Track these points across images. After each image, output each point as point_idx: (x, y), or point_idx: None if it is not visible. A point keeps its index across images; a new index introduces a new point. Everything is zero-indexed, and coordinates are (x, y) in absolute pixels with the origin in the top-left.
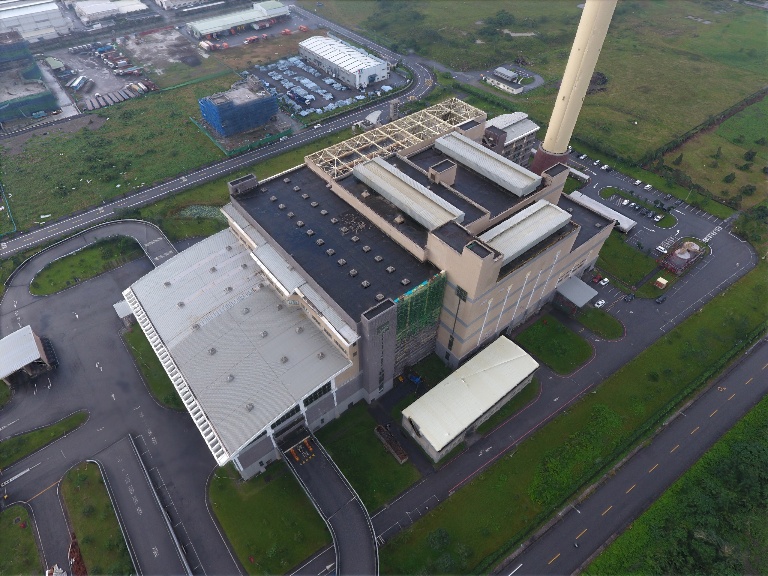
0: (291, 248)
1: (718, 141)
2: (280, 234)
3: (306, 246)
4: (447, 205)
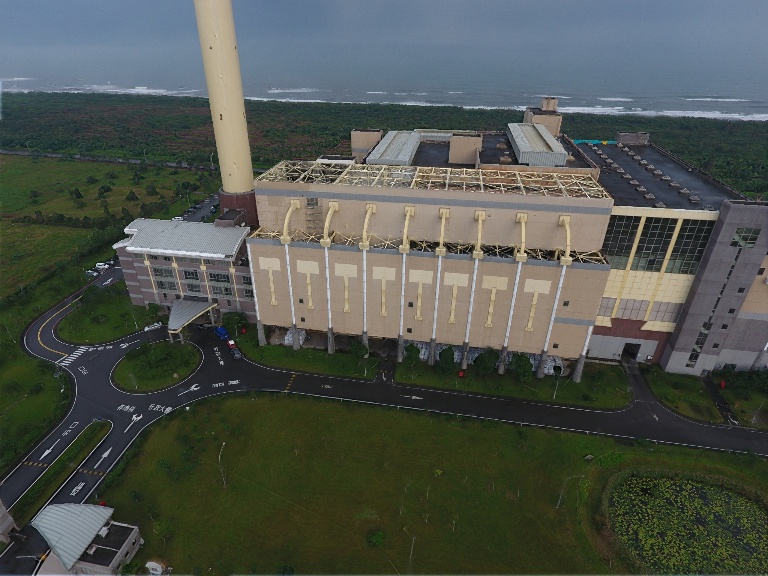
0: (688, 174)
1: (36, 209)
2: (698, 182)
3: (669, 171)
4: (514, 126)
